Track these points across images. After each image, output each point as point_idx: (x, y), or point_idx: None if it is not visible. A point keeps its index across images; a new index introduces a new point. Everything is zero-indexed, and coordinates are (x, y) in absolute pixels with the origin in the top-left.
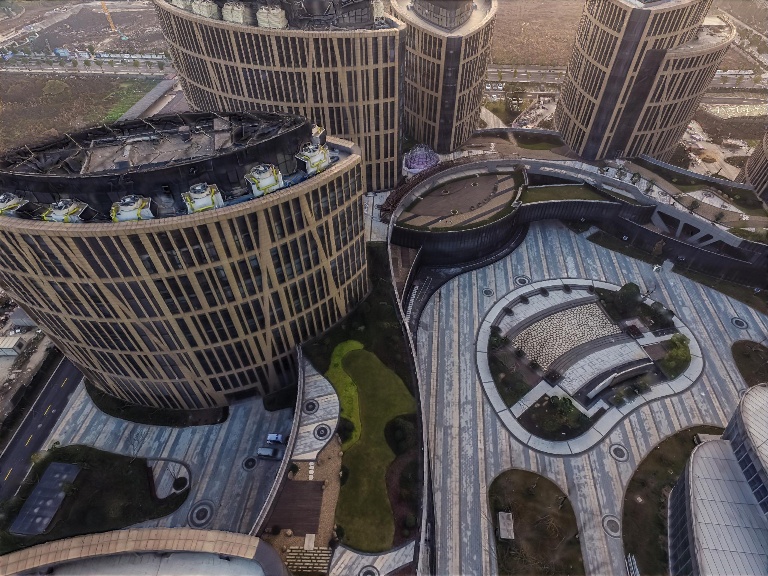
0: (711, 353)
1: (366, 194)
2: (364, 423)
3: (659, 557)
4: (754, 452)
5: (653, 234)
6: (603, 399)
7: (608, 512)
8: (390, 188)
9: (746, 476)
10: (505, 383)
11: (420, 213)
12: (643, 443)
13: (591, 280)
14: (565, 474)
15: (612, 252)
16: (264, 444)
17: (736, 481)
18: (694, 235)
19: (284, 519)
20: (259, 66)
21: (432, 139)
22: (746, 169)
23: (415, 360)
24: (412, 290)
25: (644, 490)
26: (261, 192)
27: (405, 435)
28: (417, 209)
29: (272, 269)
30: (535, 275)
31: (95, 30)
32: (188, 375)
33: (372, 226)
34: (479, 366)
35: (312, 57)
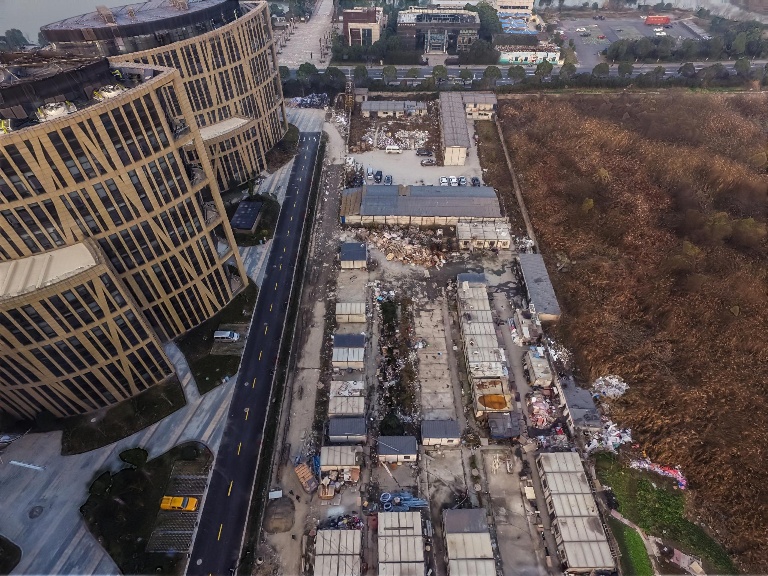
0: None
1: None
2: None
3: None
4: None
5: None
6: None
7: None
8: None
9: None
10: None
11: None
12: None
13: None
14: None
15: None
16: None
17: None
18: None
19: None
20: None
21: None
22: None
23: None
24: None
25: None
26: None
27: None
28: None
29: None
30: None
31: None
32: None
33: None
34: None
35: None
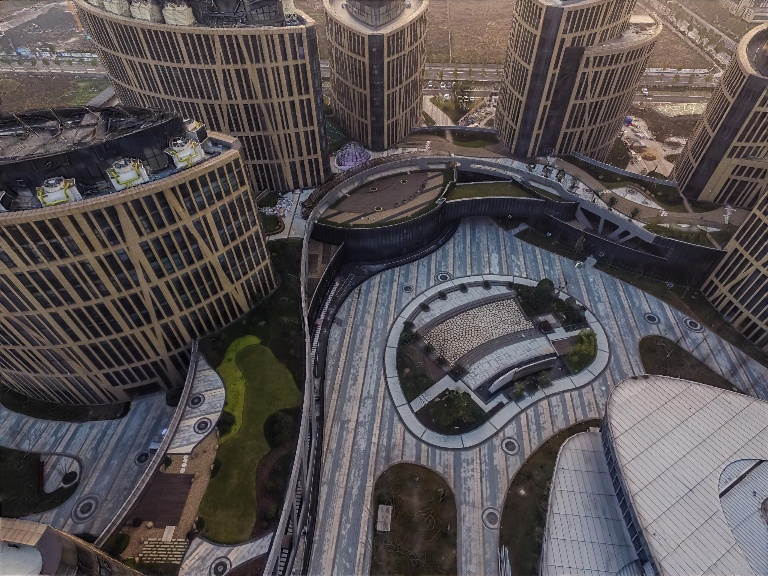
0: (618, 348)
1: (293, 191)
2: (246, 417)
3: (532, 549)
4: (611, 443)
5: (575, 230)
6: (504, 393)
7: (489, 505)
8: (318, 185)
9: (609, 467)
10: (408, 378)
11: (344, 210)
12: (536, 437)
13: (512, 276)
14: (453, 467)
15: (537, 249)
16: (160, 439)
17: (599, 472)
18: (614, 231)
19: (148, 511)
20: (170, 63)
21: (366, 137)
22: (675, 166)
23: (307, 354)
24: (332, 286)
25: (528, 483)
26: (123, 186)
27: (281, 428)
28: (342, 206)
29: (146, 263)
30: (457, 271)
31: (63, 29)
32: (79, 370)
33: (293, 223)
34: (386, 361)
35: (220, 54)
